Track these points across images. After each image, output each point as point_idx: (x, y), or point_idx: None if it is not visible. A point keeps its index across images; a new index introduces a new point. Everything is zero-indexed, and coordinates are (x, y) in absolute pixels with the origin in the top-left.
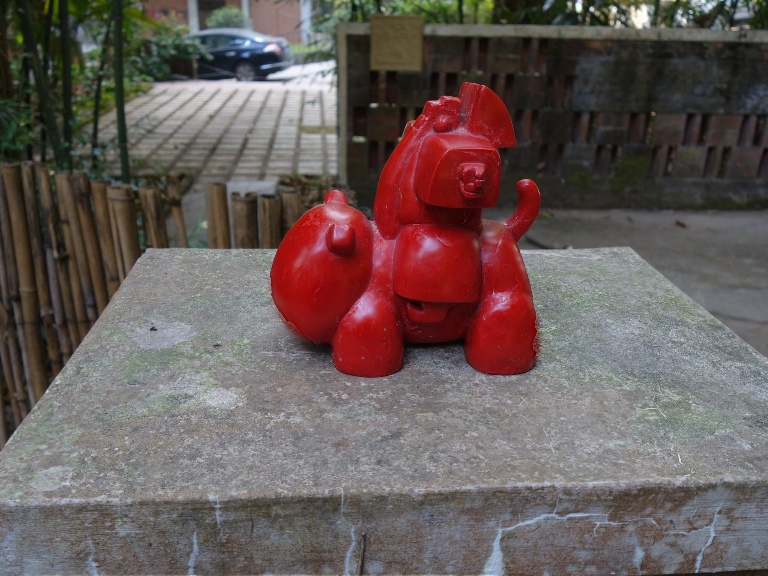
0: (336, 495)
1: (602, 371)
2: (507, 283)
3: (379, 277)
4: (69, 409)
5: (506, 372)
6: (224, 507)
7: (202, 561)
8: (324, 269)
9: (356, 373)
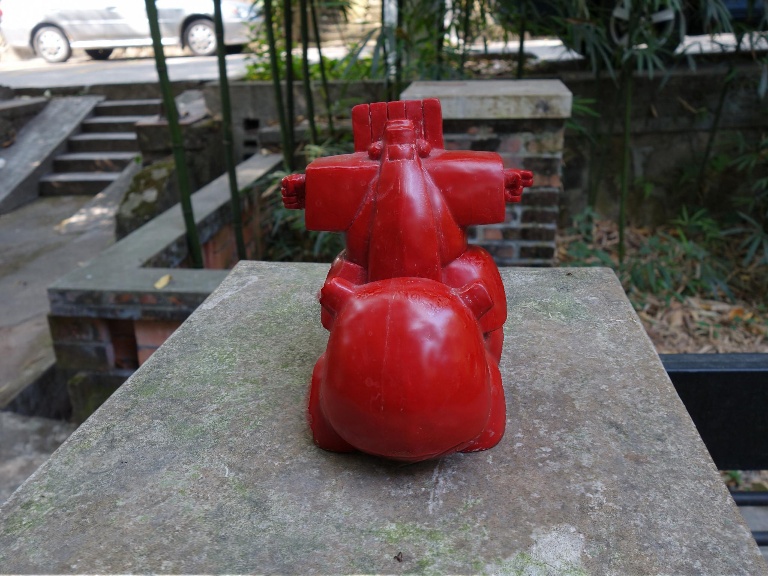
0: None
1: None
2: None
3: None
4: None
5: None
6: None
7: None
8: None
9: None
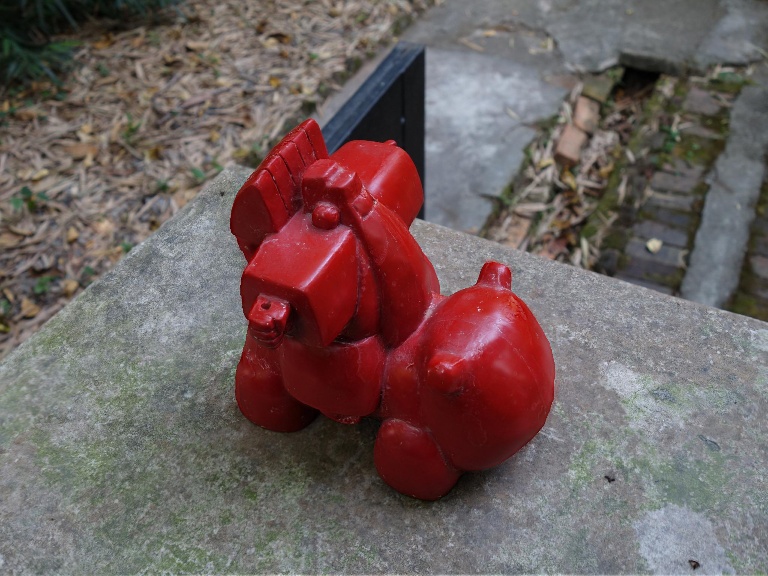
0: None
1: None
2: None
3: None
4: None
5: None
6: None
7: None
8: None
9: None
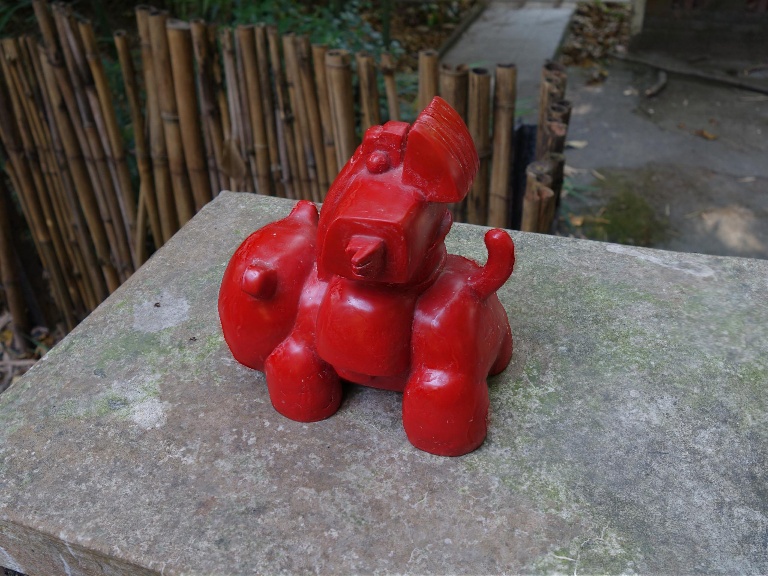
0: (157, 570)
1: (555, 478)
2: (439, 360)
3: (303, 324)
4: (33, 393)
5: (435, 451)
6: (72, 547)
7: (75, 574)
8: (243, 309)
9: (281, 412)
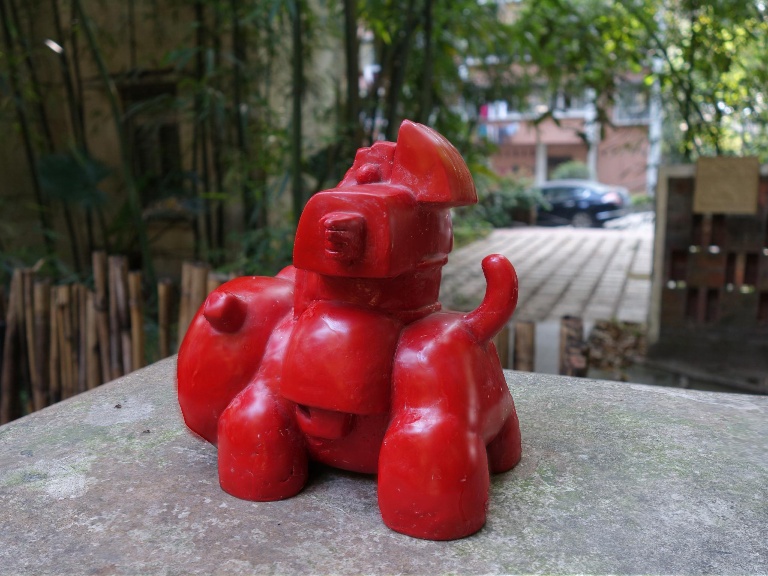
0: None
1: (577, 568)
2: (425, 395)
3: (269, 366)
4: None
5: (416, 533)
6: None
7: None
8: (203, 347)
9: (228, 490)
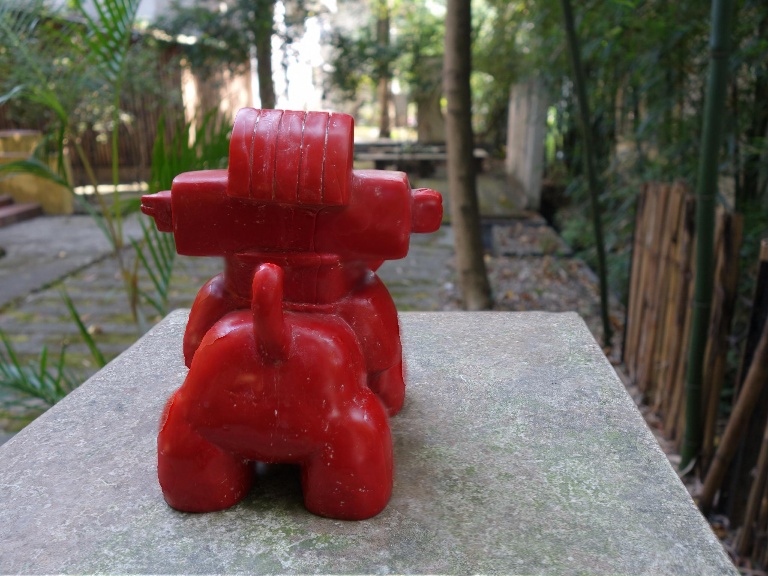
0: None
1: (115, 575)
2: None
3: None
4: None
5: None
6: None
7: None
8: None
9: None
